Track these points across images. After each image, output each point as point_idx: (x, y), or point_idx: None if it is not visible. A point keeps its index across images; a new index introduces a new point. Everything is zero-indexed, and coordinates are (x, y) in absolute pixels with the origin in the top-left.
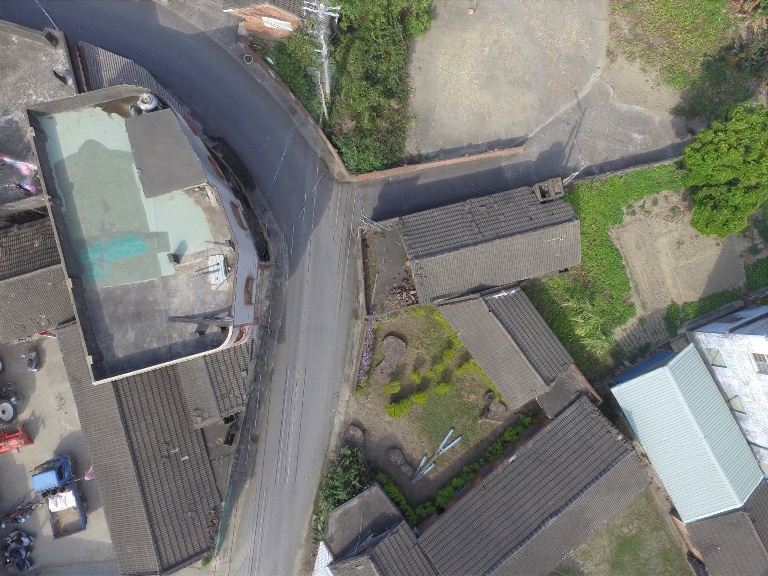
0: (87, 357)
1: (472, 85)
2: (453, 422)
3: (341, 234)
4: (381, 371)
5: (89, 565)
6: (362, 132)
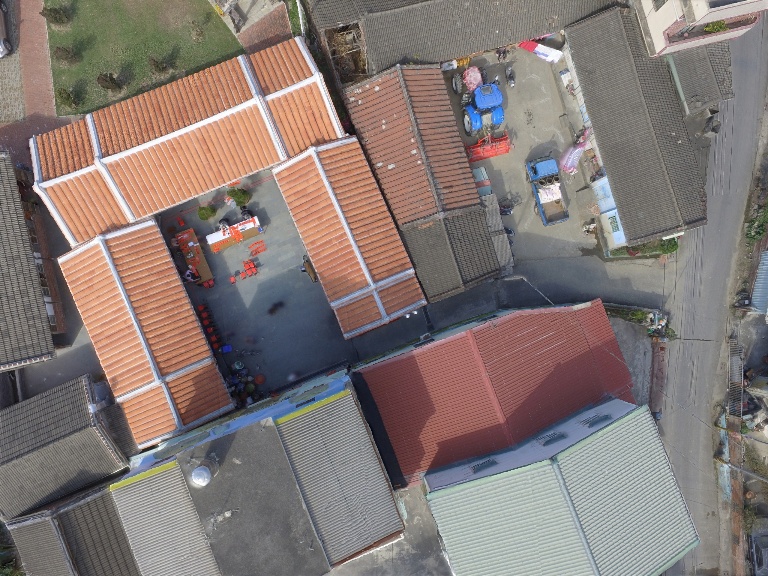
0: None
1: None
2: None
3: None
4: None
5: (558, 260)
6: None
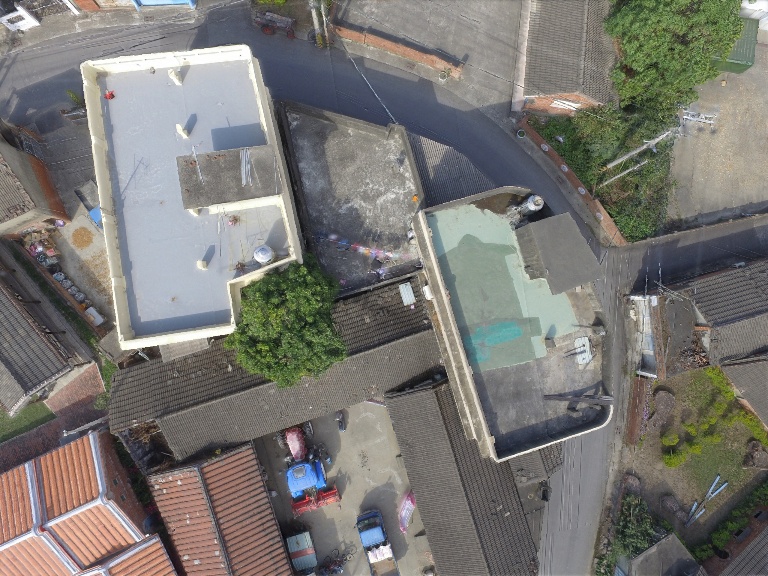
0: (491, 437)
1: (726, 153)
2: (718, 469)
3: (610, 296)
4: (654, 423)
5: None
6: (631, 201)
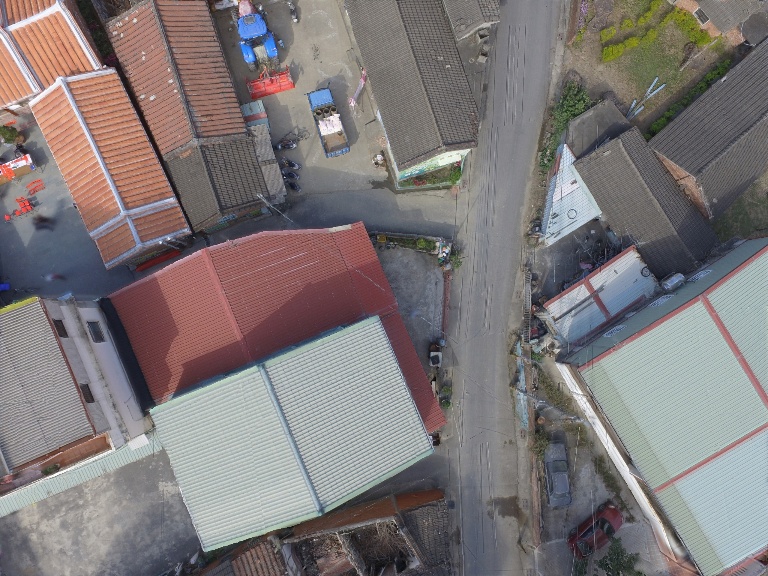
0: None
1: None
2: (657, 72)
3: None
4: (594, 25)
5: (347, 193)
6: None
